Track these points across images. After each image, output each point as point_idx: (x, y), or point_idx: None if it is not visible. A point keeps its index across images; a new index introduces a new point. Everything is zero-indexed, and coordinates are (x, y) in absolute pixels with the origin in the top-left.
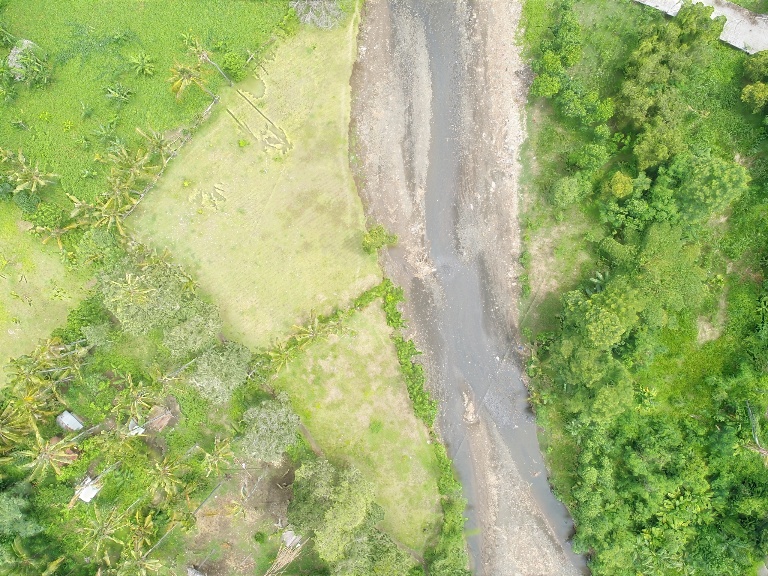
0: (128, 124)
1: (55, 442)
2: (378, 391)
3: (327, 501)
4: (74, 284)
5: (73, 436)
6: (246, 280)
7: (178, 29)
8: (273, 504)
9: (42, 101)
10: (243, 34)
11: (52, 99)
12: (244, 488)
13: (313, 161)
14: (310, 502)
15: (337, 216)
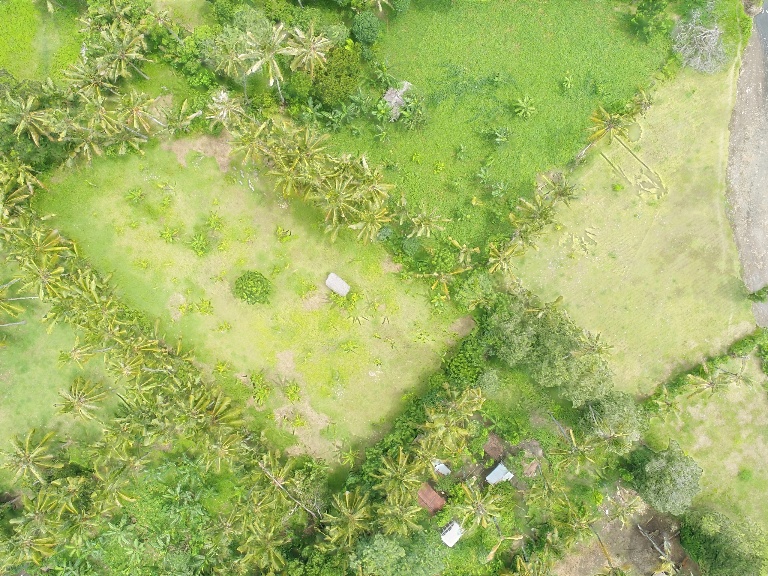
0: (500, 167)
1: (424, 487)
2: (748, 439)
3: (755, 558)
4: (438, 327)
5: (446, 481)
6: (615, 325)
7: (555, 71)
8: (635, 551)
9: (412, 142)
10: (622, 77)
11: (422, 140)
12: (668, 543)
13: (688, 206)
14: (744, 560)
15: (711, 262)
